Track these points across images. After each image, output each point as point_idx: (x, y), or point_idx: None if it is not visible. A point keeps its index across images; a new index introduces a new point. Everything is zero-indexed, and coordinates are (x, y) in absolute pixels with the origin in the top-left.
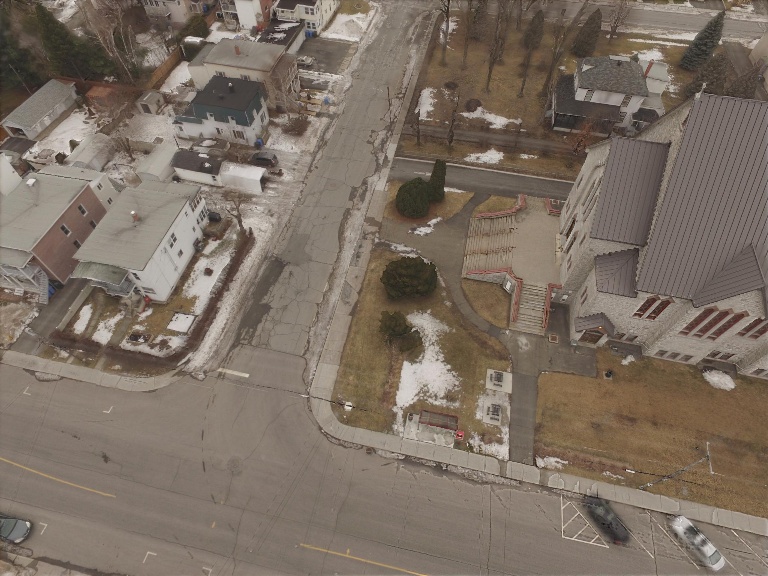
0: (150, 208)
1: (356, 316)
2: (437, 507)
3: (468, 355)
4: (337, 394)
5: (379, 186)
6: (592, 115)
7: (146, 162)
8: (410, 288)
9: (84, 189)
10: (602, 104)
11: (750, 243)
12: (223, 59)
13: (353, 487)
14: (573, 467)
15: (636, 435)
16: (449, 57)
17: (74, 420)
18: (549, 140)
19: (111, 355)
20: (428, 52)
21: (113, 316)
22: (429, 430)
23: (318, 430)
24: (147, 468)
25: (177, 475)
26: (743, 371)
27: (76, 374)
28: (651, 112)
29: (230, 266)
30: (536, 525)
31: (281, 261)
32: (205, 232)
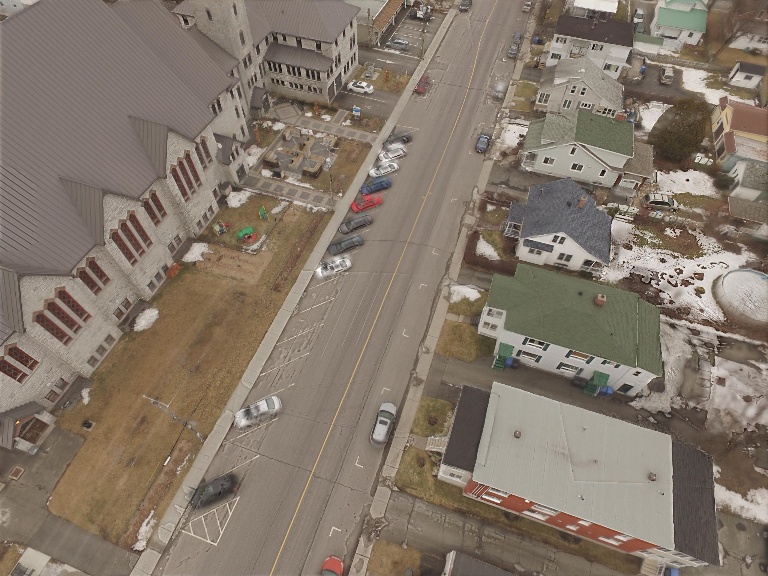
0: None
1: None
2: None
3: None
4: None
5: None
6: None
7: None
8: None
9: None
10: None
11: None
12: None
13: None
14: (159, 506)
15: (158, 423)
16: None
17: None
18: None
19: None
20: None
21: None
22: None
23: None
24: None
25: None
26: (147, 297)
27: None
28: None
29: None
30: (196, 574)
31: None
32: None
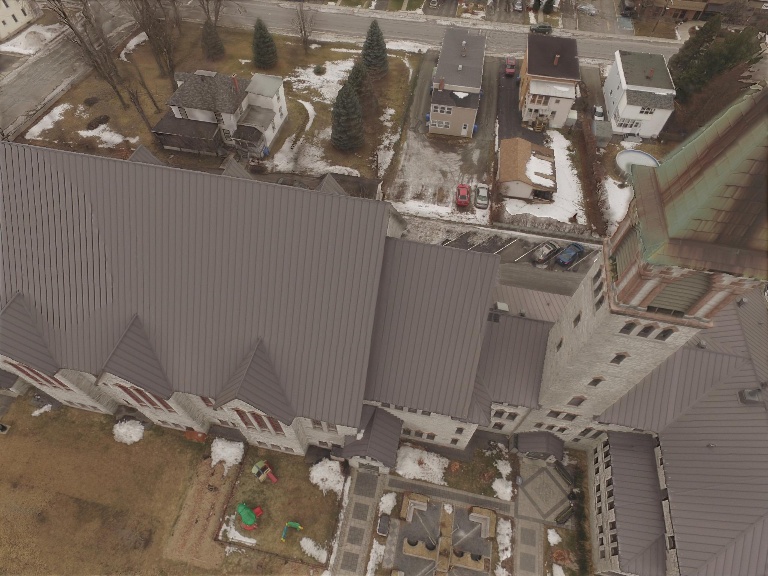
0: None
1: None
2: None
3: None
4: None
5: None
6: (186, 133)
7: None
8: None
9: None
10: (200, 121)
11: (16, 291)
12: None
13: None
14: None
15: None
16: None
17: None
18: None
19: None
20: None
21: None
22: None
23: None
24: None
25: None
26: (154, 422)
27: None
28: (250, 129)
29: None
30: None
31: None
32: None
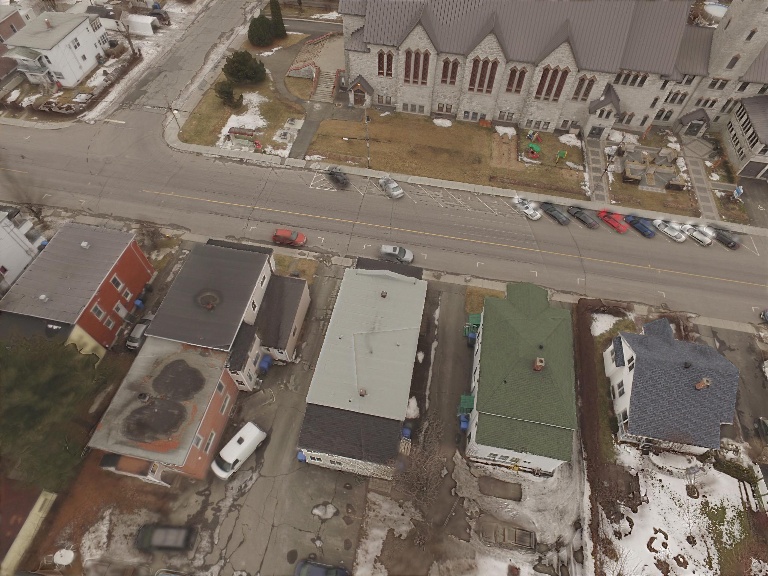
0: (60, 22)
1: (206, 95)
2: (234, 176)
3: (277, 112)
4: (183, 130)
5: (242, 32)
6: None
7: (66, 12)
8: (241, 73)
9: (14, 13)
10: None
11: (423, 3)
12: None
13: (183, 168)
14: (328, 159)
15: (375, 146)
16: None
17: (3, 141)
18: None
19: (31, 111)
20: None
21: (35, 95)
22: (240, 145)
23: (166, 146)
24: (50, 161)
25: (69, 163)
26: (458, 116)
27: (7, 122)
28: None
29: (121, 69)
30: (295, 183)
31: (160, 70)
32: (106, 52)
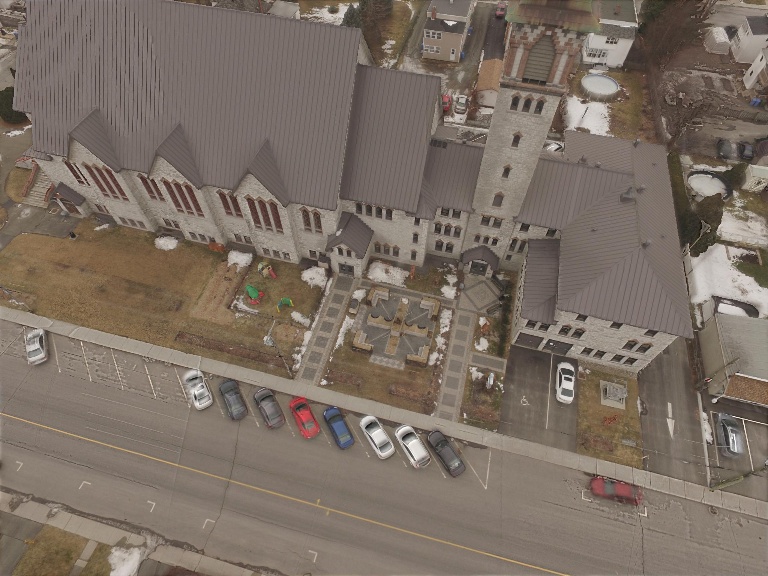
0: None
1: None
2: None
3: None
4: None
5: None
6: None
7: None
8: None
9: None
10: None
11: (94, 107)
12: None
13: None
14: None
15: (59, 277)
16: None
17: None
18: None
19: None
20: None
21: None
22: None
23: None
24: None
25: None
26: (185, 236)
27: None
28: None
29: None
30: None
31: None
32: None
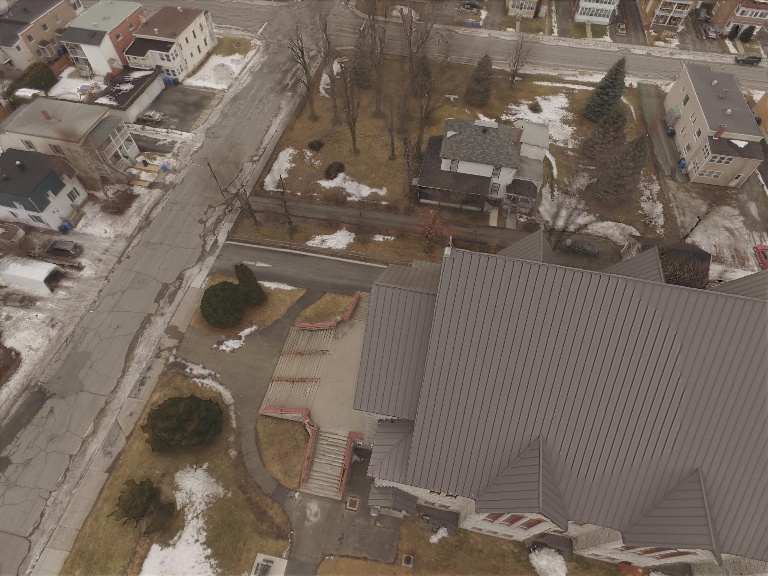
0: None
1: (113, 474)
2: None
3: (237, 533)
4: None
5: (196, 282)
6: (458, 188)
7: None
8: (175, 441)
9: None
10: (471, 175)
11: (538, 435)
12: (27, 126)
13: None
14: None
15: None
16: (323, 108)
17: None
18: (412, 216)
19: None
20: (301, 102)
21: None
22: None
23: None
24: None
25: None
26: (578, 552)
27: None
28: (527, 184)
29: None
30: None
31: (44, 392)
32: None
